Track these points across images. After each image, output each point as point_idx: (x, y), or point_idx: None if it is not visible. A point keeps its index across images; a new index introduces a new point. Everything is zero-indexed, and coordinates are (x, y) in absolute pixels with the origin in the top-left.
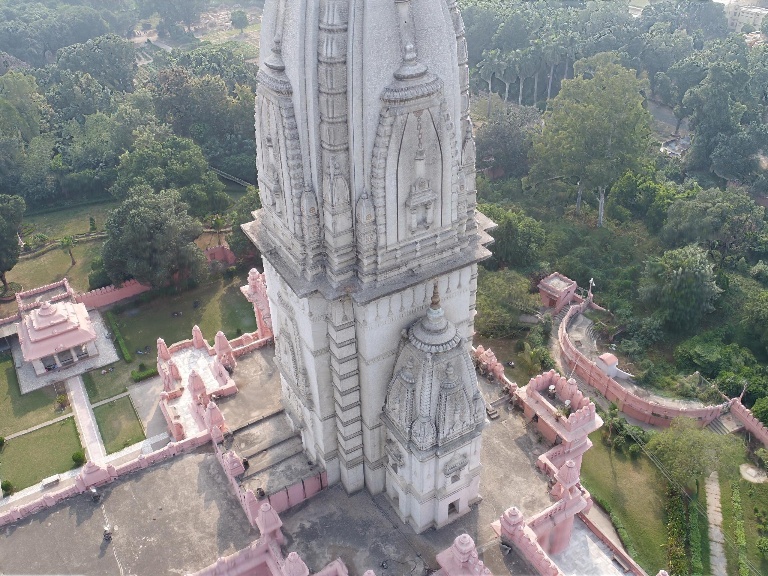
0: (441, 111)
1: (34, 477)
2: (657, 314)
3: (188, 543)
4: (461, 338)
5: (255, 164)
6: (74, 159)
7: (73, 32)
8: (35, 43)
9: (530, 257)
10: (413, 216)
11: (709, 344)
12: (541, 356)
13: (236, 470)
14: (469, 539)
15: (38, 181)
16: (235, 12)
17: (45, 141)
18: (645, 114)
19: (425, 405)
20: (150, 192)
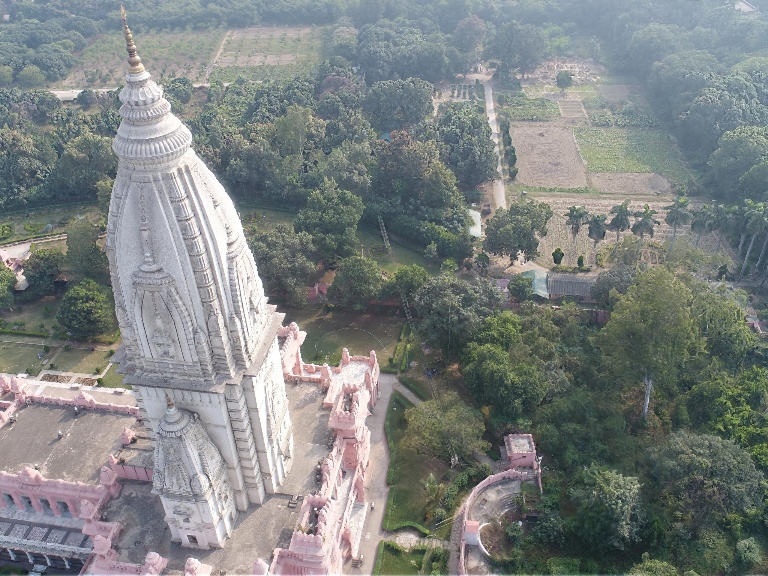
0: (168, 296)
1: (117, 383)
2: (569, 520)
3: (83, 464)
4: (183, 434)
5: (417, 228)
6: (310, 178)
7: (419, 62)
8: (385, 66)
9: (509, 409)
10: (158, 348)
11: (579, 573)
12: (446, 493)
13: (125, 440)
14: (153, 557)
15: (280, 186)
16: (562, 72)
17: (296, 160)
18: (724, 330)
19: (155, 461)
20: (291, 230)
